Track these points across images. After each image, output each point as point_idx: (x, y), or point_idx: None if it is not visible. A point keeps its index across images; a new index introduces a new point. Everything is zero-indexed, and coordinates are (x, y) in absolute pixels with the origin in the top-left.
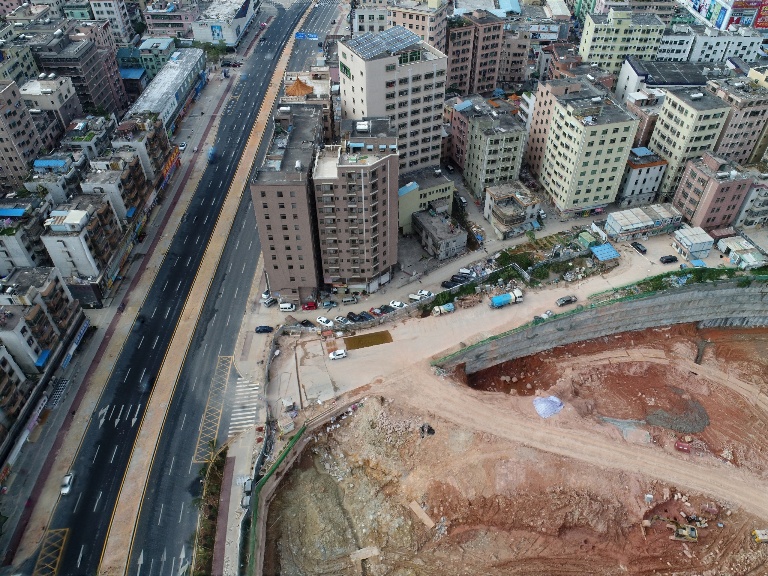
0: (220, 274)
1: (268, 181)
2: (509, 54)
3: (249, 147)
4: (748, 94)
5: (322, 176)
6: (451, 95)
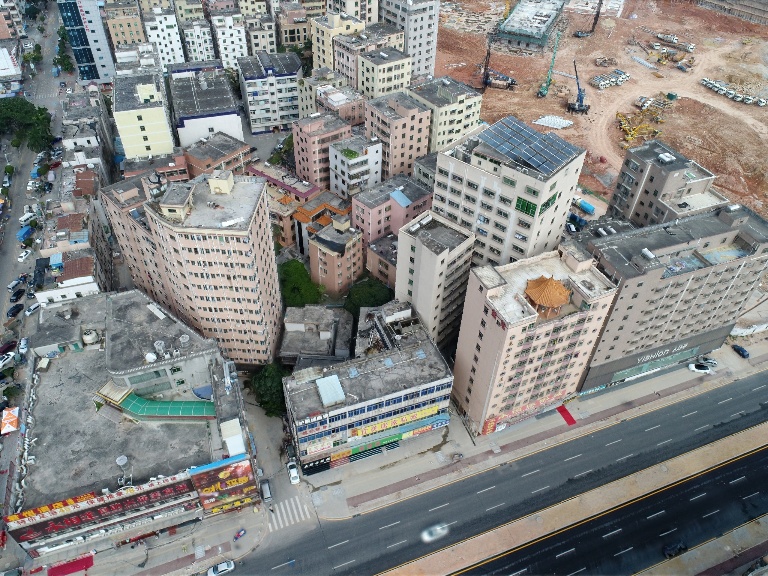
0: (720, 431)
1: (762, 234)
2: (97, 231)
3: (431, 574)
4: (373, 38)
5: (713, 203)
6: (316, 241)
